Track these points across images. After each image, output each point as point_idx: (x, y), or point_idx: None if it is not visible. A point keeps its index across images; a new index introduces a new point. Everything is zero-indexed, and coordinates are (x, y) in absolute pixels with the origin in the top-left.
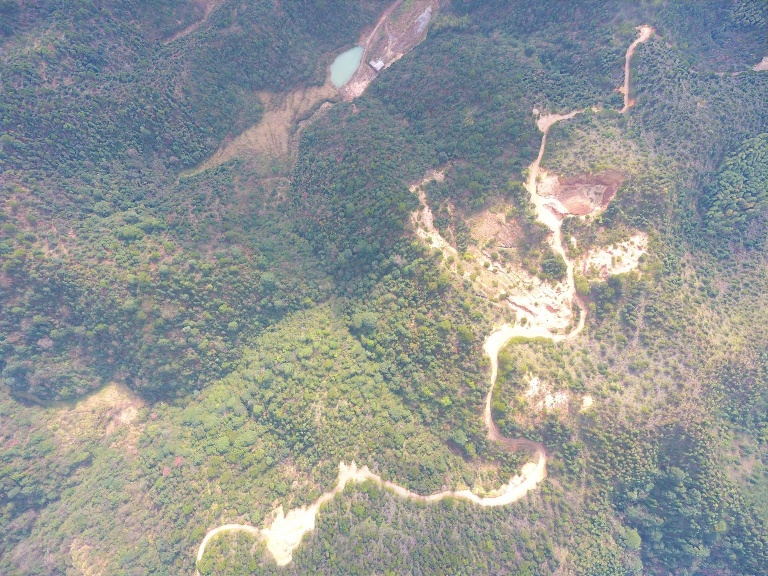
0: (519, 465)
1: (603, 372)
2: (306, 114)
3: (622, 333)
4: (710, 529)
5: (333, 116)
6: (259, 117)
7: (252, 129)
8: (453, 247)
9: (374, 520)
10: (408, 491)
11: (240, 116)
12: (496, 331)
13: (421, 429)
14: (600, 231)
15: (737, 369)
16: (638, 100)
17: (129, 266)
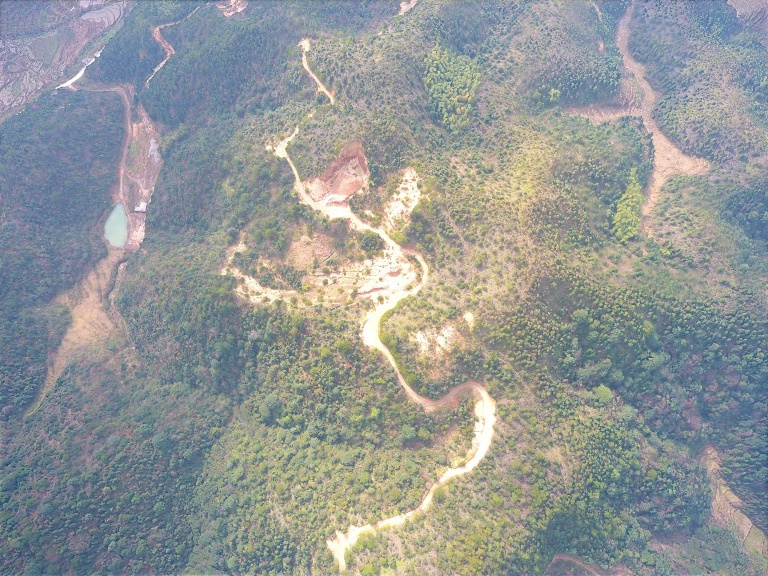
0: (470, 413)
1: (462, 286)
2: (109, 286)
3: (453, 248)
4: (644, 335)
5: (130, 270)
6: (68, 318)
7: (69, 332)
8: (290, 290)
9: (387, 566)
10: (402, 515)
11: (49, 329)
12: (364, 324)
13: (378, 454)
14: (380, 191)
15: (546, 206)
16: (335, 88)
17: (8, 533)
